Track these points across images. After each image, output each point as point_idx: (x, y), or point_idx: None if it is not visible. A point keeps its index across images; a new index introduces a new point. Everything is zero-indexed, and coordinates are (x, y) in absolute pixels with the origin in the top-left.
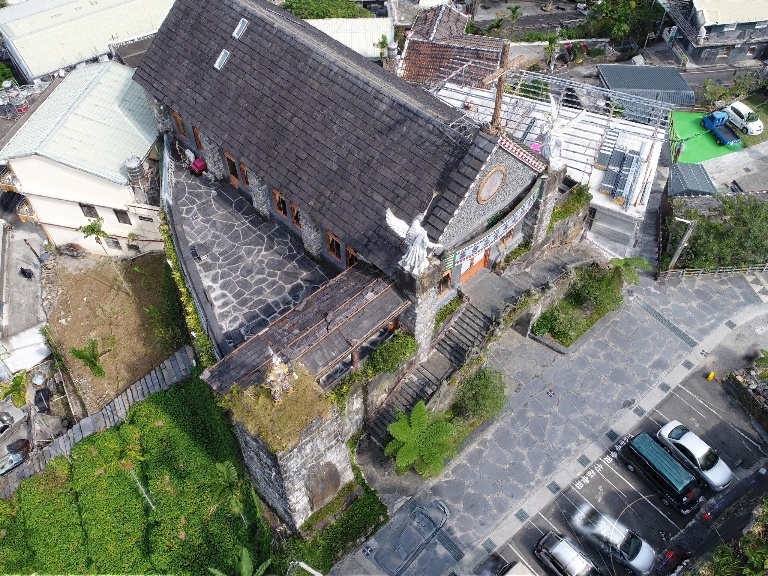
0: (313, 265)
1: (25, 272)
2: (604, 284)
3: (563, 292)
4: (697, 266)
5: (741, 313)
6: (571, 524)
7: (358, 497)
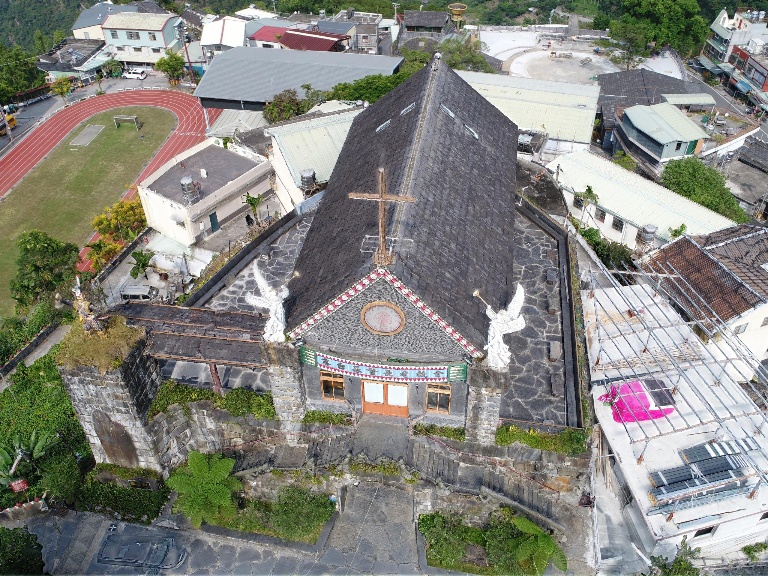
0: None
1: (249, 219)
2: (513, 542)
3: (480, 517)
4: None
5: None
6: None
7: (152, 488)
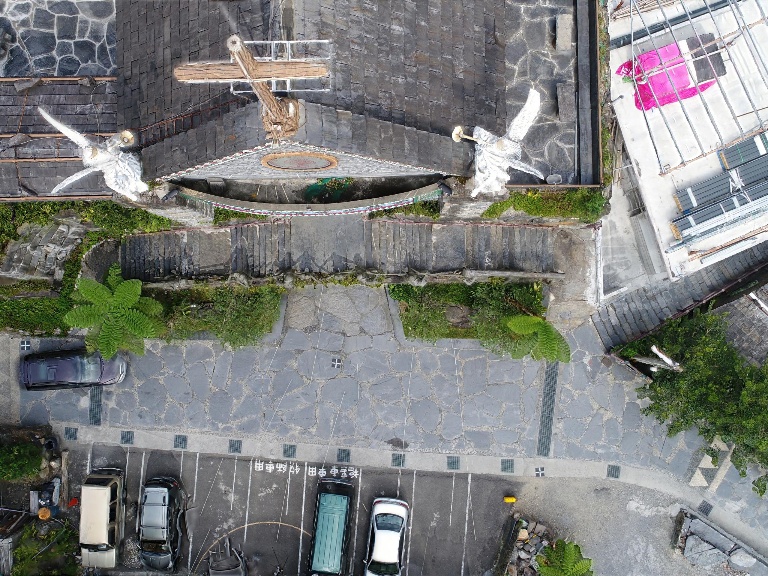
0: None
1: None
2: (505, 320)
3: None
4: (645, 396)
5: (644, 471)
6: (213, 488)
7: None
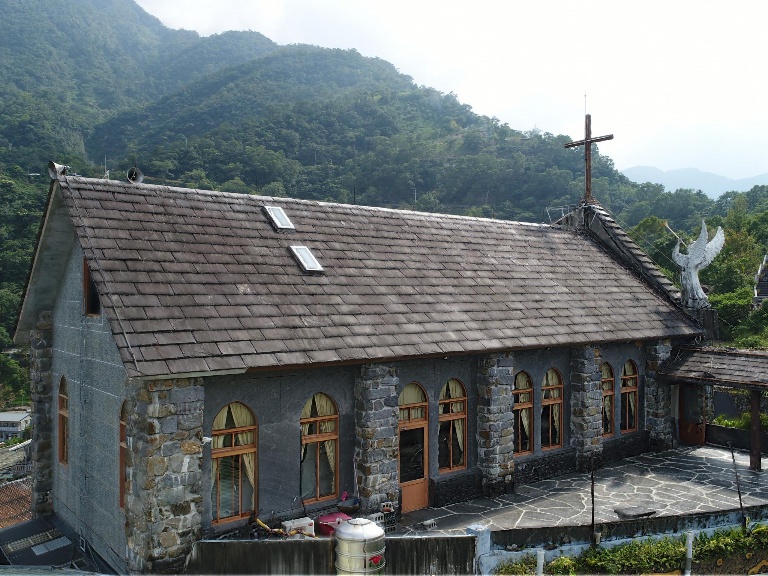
0: (607, 470)
1: None
2: None
3: None
4: None
5: None
6: None
7: None
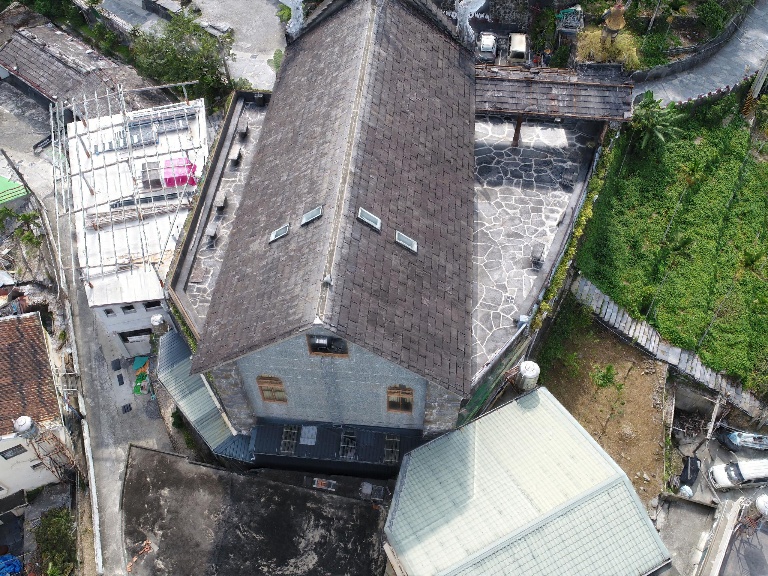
0: None
1: None
2: None
3: None
4: None
5: (239, 56)
6: None
7: None
